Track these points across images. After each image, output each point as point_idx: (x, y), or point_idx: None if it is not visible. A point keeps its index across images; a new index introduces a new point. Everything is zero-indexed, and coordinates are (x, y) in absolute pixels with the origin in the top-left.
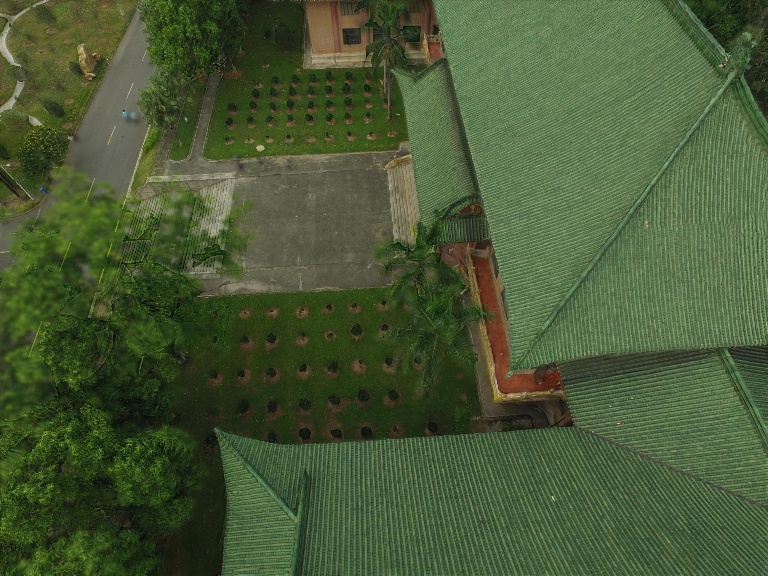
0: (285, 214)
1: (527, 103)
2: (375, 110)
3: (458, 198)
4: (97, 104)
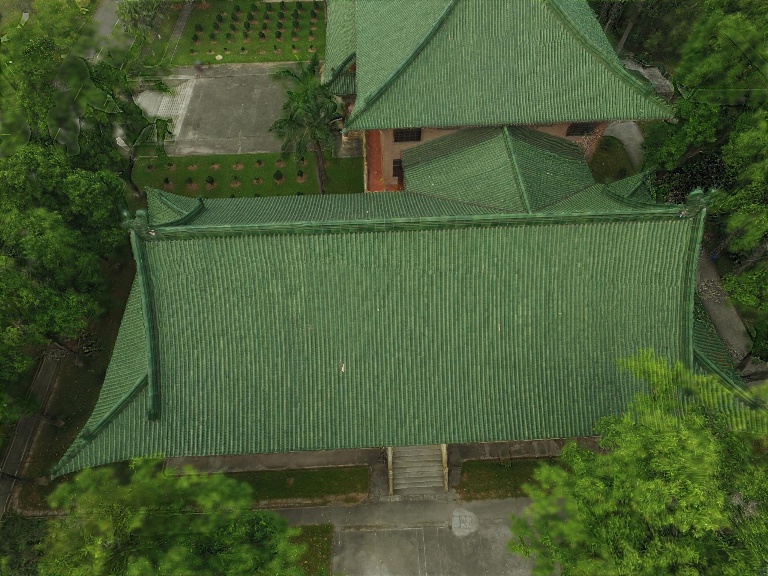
0: (233, 103)
1: None
2: (318, 31)
3: (347, 57)
4: (89, 32)
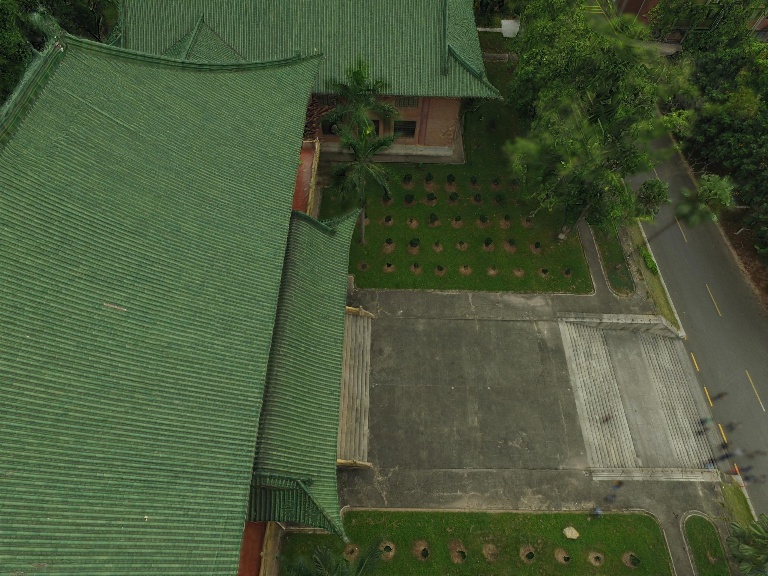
0: (504, 393)
1: (208, 225)
2: None
3: None
4: None
